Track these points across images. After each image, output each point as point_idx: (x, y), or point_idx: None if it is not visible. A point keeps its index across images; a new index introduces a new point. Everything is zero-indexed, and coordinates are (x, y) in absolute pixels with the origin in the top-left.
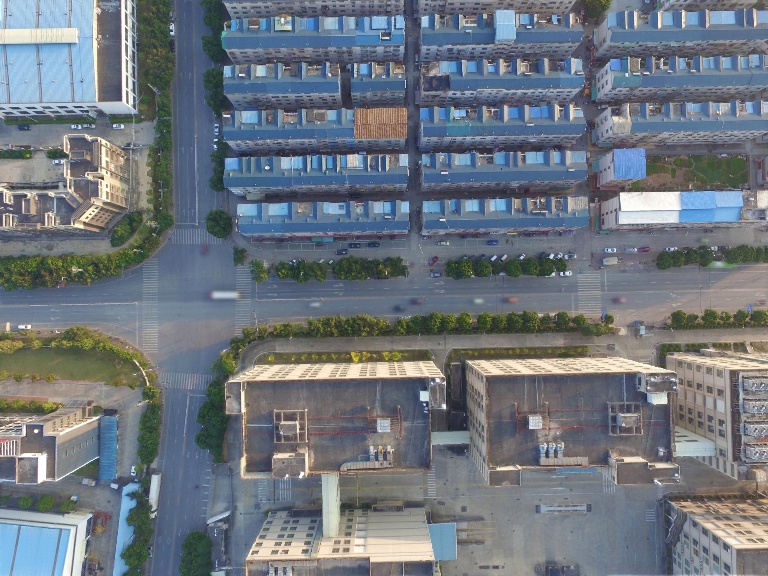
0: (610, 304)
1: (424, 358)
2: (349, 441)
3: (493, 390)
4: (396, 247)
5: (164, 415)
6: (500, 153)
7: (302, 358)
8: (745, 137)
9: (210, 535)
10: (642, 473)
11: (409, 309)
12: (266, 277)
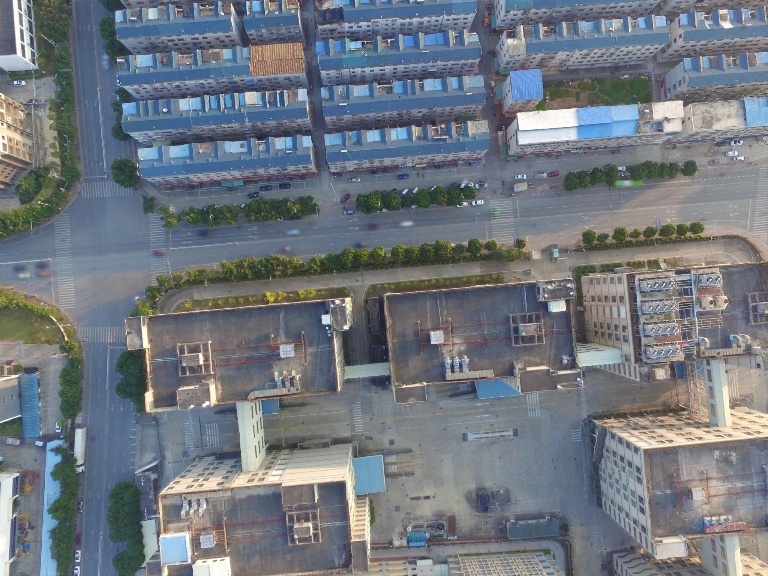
0: (524, 230)
1: (342, 295)
2: (255, 370)
3: (395, 310)
4: (308, 187)
5: (85, 370)
6: (398, 82)
7: (219, 302)
8: (643, 55)
9: (137, 484)
10: (545, 380)
11: (324, 248)
12: (175, 222)
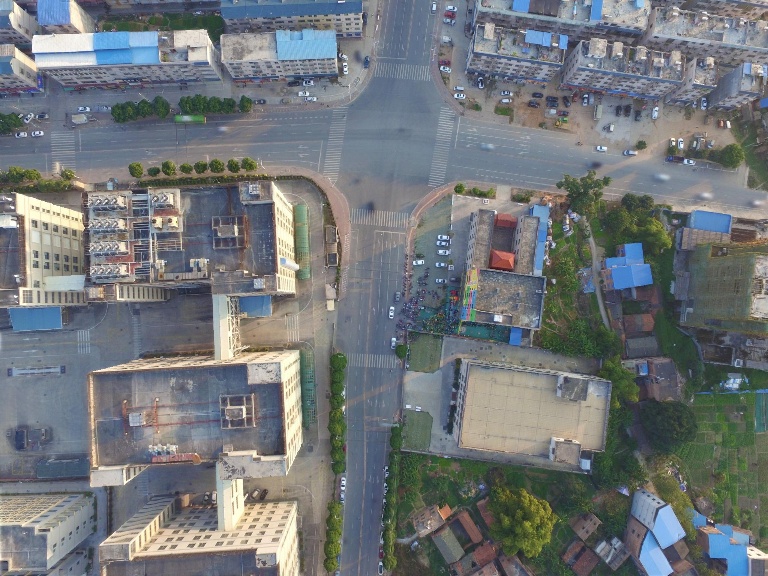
0: (85, 163)
1: None
2: None
3: None
4: None
5: None
6: None
7: None
8: None
9: None
10: None
11: None
12: None
